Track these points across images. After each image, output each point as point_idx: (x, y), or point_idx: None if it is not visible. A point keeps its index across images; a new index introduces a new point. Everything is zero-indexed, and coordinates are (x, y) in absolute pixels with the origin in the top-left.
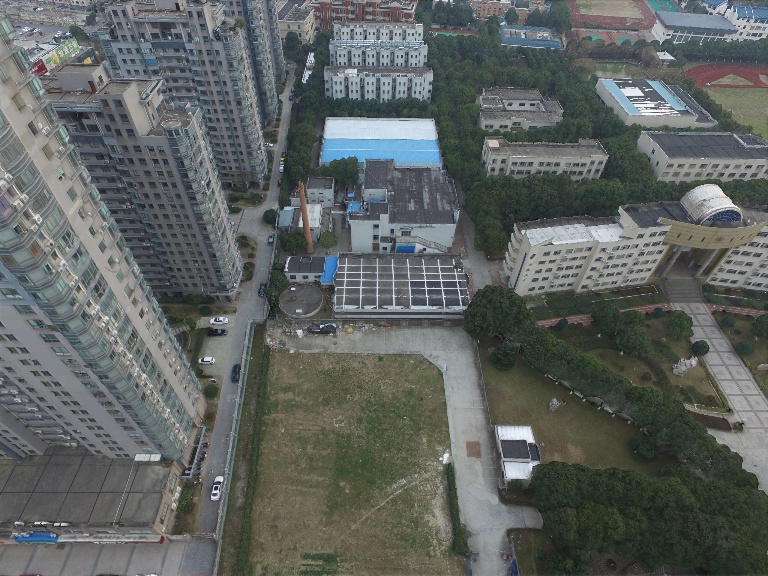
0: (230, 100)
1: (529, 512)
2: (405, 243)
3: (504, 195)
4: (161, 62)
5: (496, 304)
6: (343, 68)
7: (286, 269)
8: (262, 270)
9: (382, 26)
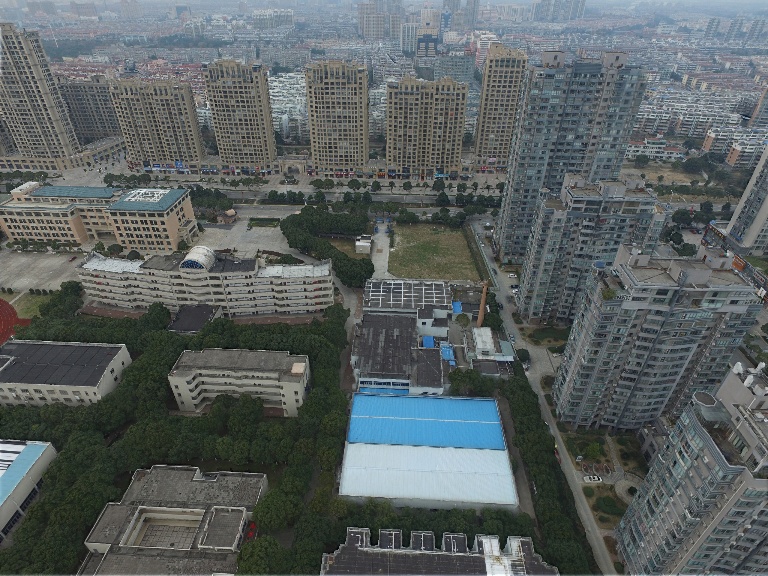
0: None
1: None
2: None
3: None
4: None
5: None
6: None
7: None
8: (508, 319)
9: None
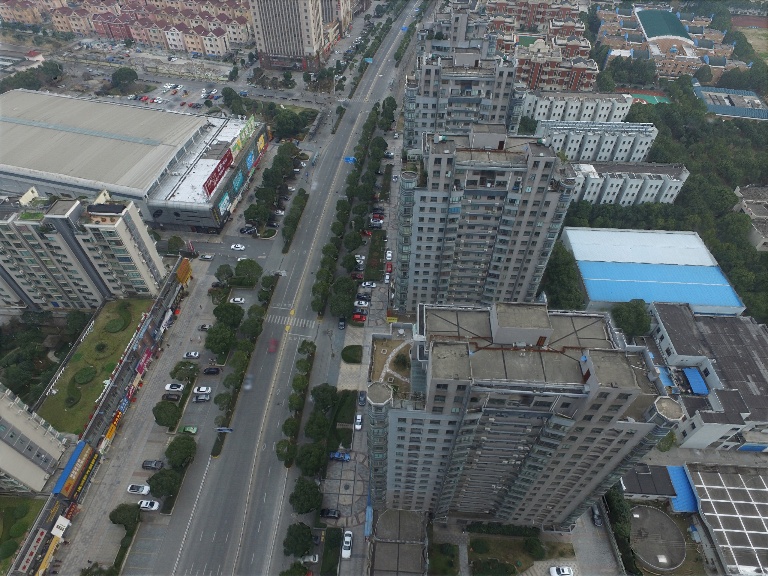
0: (533, 250)
1: None
2: (757, 443)
3: None
4: (463, 209)
5: None
6: (574, 163)
7: (623, 486)
8: None
9: (586, 98)
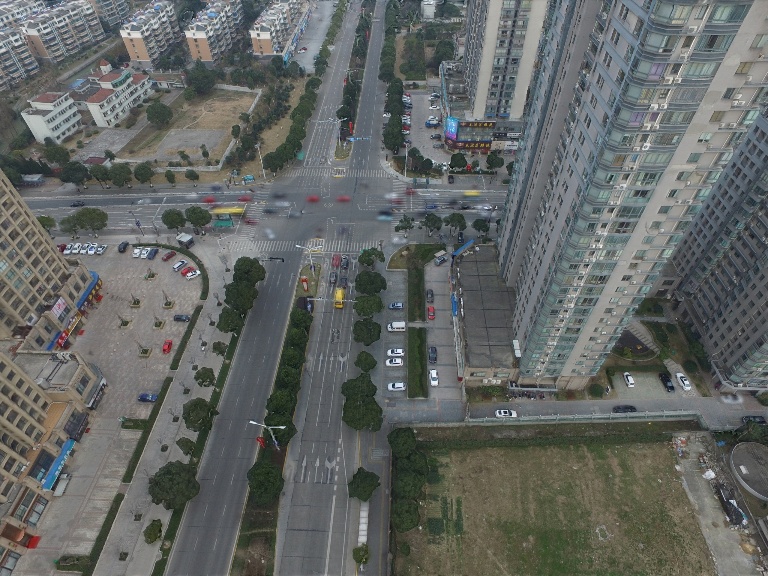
0: None
1: None
2: None
3: None
4: None
5: None
6: None
7: None
8: None
9: None
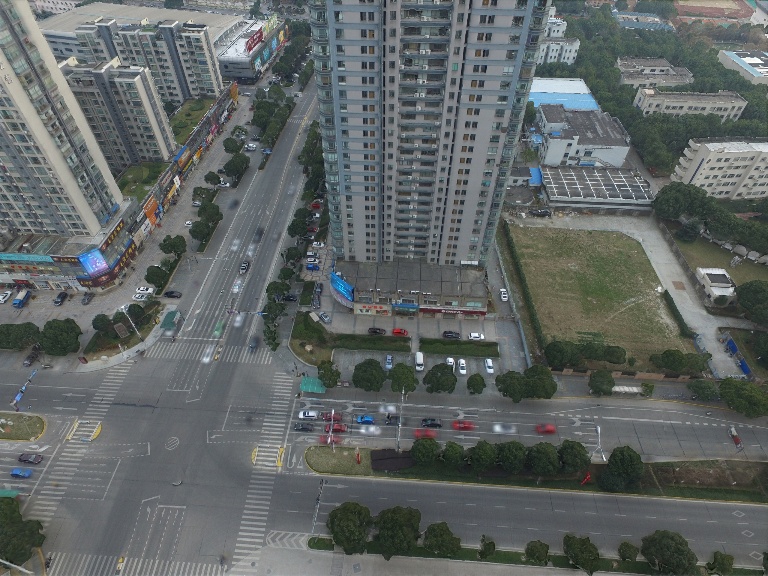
0: None
1: (731, 320)
2: (587, 161)
3: (666, 127)
4: None
5: (685, 192)
6: None
7: None
8: None
9: None
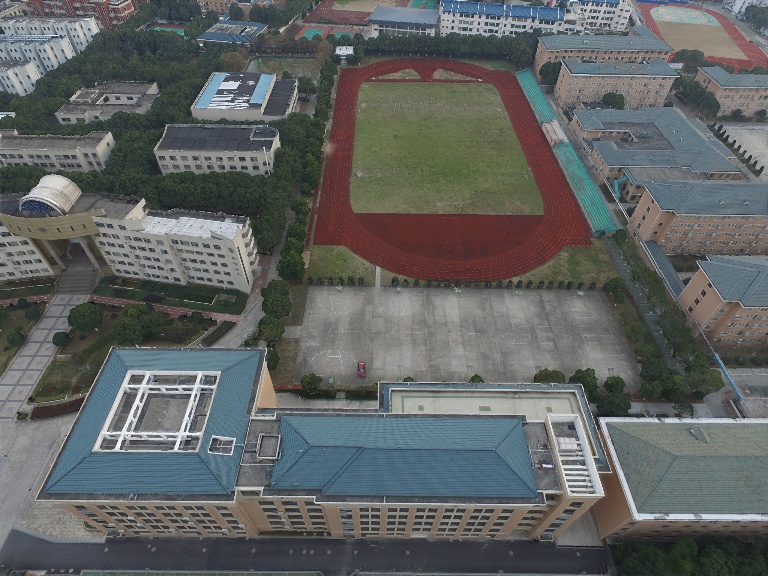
0: None
1: None
2: None
3: None
4: None
5: None
6: None
7: None
8: None
9: (45, 21)
